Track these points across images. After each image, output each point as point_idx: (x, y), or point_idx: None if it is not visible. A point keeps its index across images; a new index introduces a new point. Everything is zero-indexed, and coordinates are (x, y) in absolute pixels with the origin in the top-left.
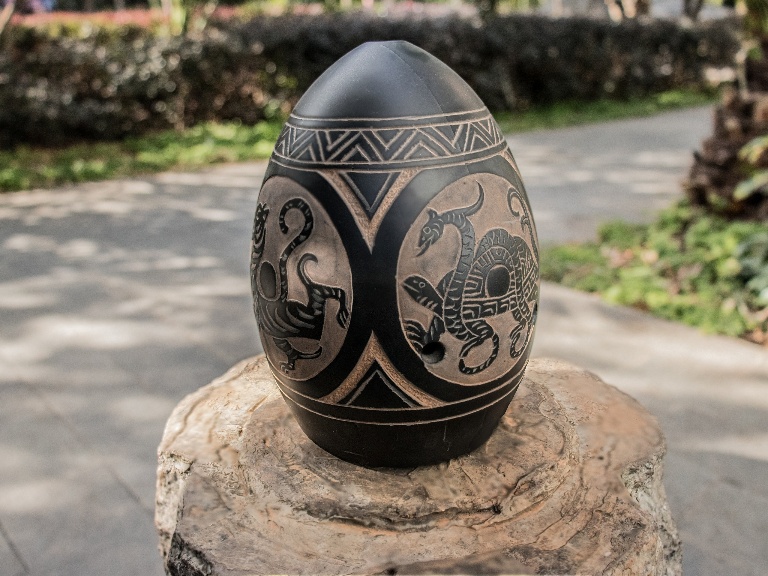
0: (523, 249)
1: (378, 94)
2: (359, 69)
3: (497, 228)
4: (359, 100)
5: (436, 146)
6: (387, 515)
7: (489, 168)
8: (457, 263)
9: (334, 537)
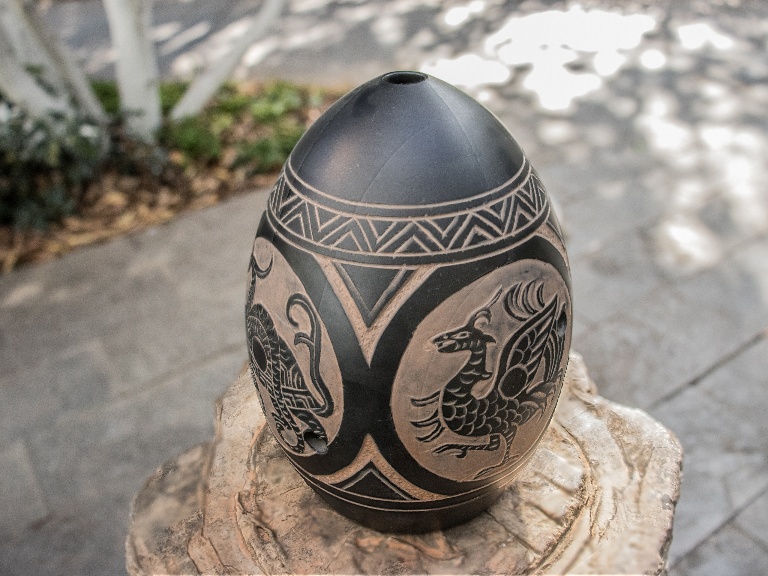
0: (288, 358)
1: None
2: None
3: (267, 310)
4: None
5: None
6: (263, 434)
7: (288, 255)
8: None
9: (261, 410)
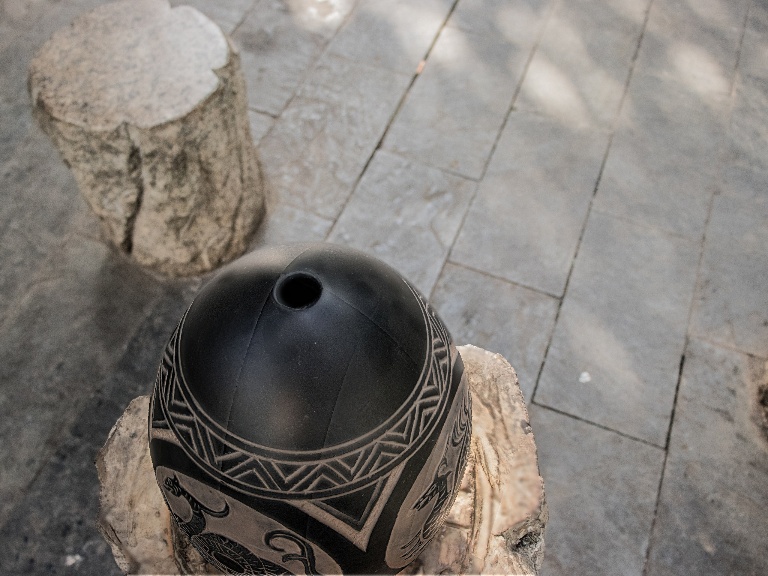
0: (276, 570)
1: (198, 353)
2: (222, 308)
3: (235, 541)
4: (191, 339)
5: (199, 445)
6: (179, 540)
7: (251, 503)
8: (187, 521)
9: (154, 510)
